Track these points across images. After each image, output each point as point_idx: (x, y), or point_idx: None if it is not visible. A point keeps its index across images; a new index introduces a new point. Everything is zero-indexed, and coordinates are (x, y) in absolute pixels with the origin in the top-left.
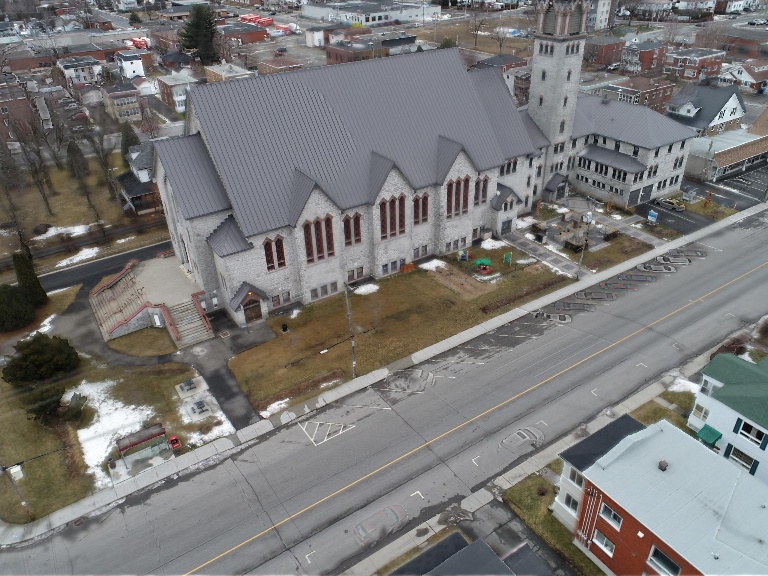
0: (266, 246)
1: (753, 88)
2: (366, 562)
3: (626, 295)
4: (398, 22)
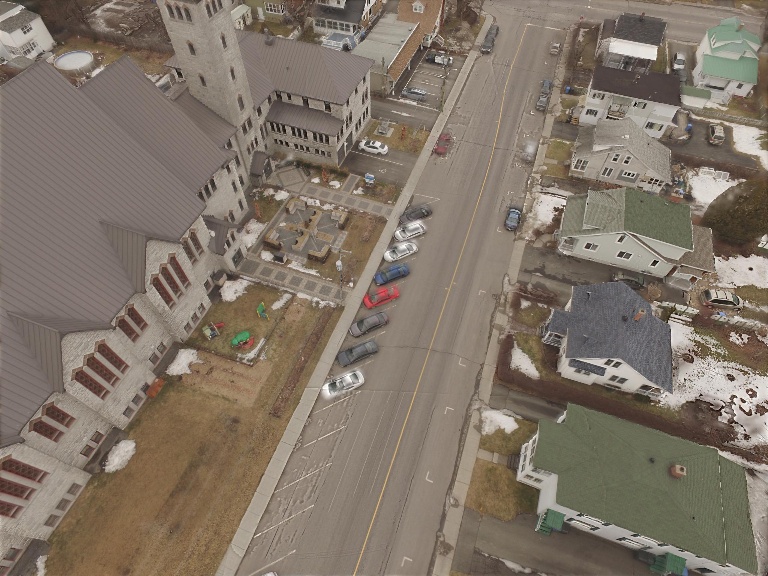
0: None
1: None
2: None
3: (393, 309)
4: None
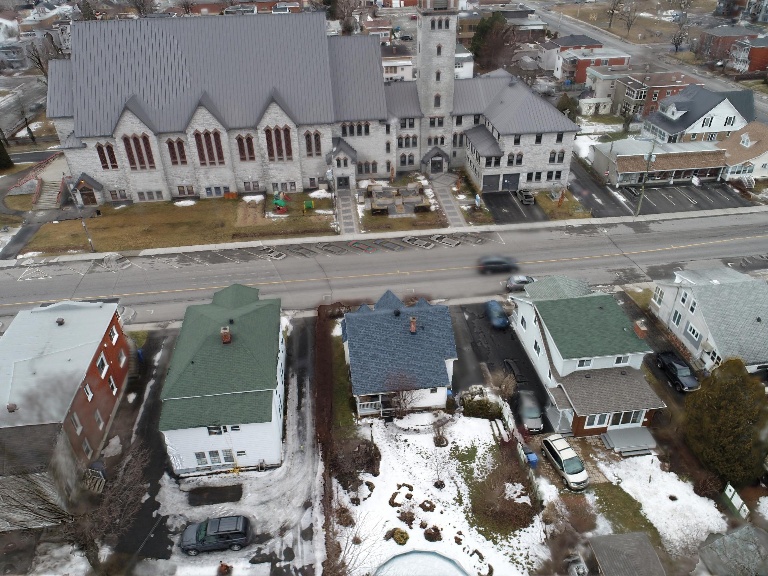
0: (100, 149)
1: None
2: None
3: (355, 254)
4: None
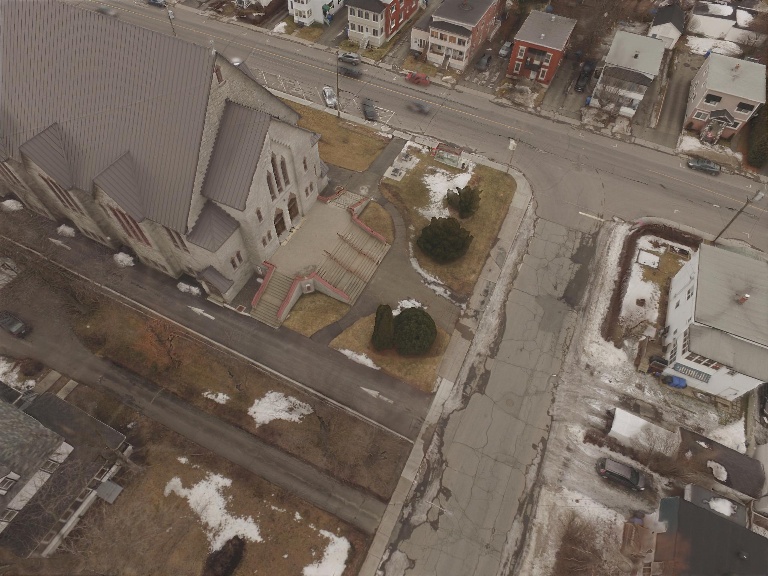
0: None
1: None
2: (433, 80)
3: None
4: None
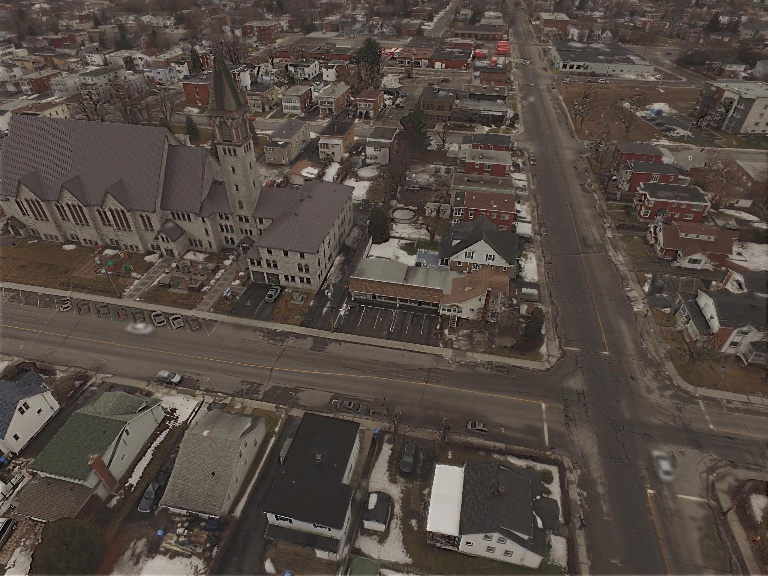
0: (18, 203)
1: (662, 253)
2: None
3: (109, 319)
4: (593, 74)
